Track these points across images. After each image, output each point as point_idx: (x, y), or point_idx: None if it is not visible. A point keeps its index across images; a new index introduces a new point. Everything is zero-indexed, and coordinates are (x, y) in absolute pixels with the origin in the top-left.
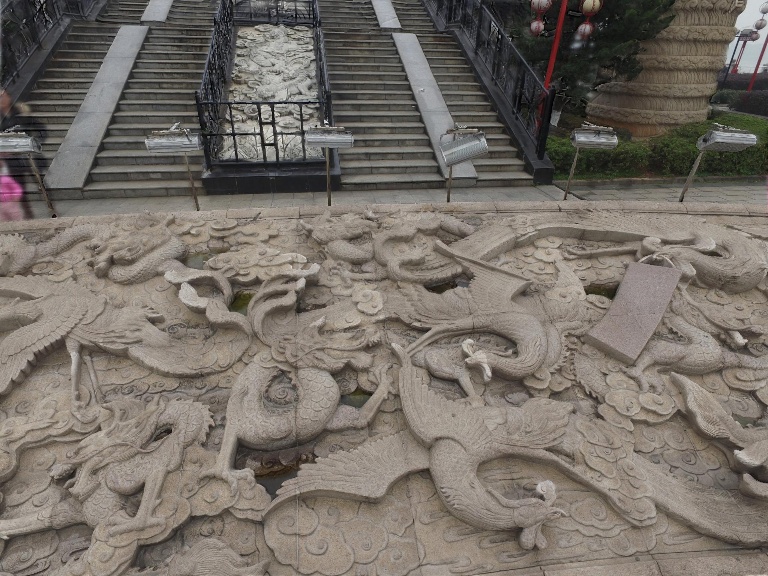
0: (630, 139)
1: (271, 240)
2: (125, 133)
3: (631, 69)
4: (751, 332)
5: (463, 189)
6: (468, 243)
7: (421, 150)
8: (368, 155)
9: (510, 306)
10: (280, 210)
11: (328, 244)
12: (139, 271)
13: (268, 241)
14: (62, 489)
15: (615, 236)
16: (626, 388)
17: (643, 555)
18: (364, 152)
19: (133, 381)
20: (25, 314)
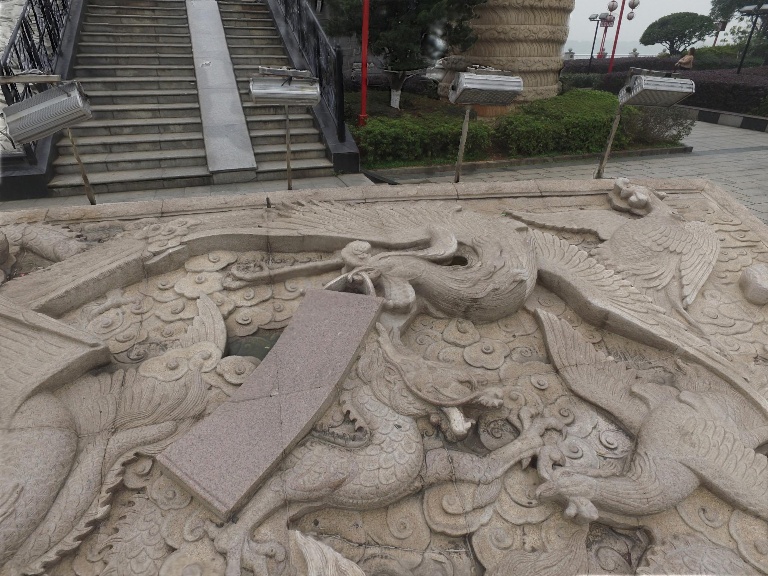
0: (474, 118)
1: None
2: None
3: (463, 37)
4: (481, 404)
5: (237, 185)
6: (42, 277)
7: (186, 137)
8: (107, 146)
9: (5, 415)
10: None
11: None
12: None
13: None
14: None
15: (317, 243)
16: None
17: None
18: (99, 142)
19: None
20: None
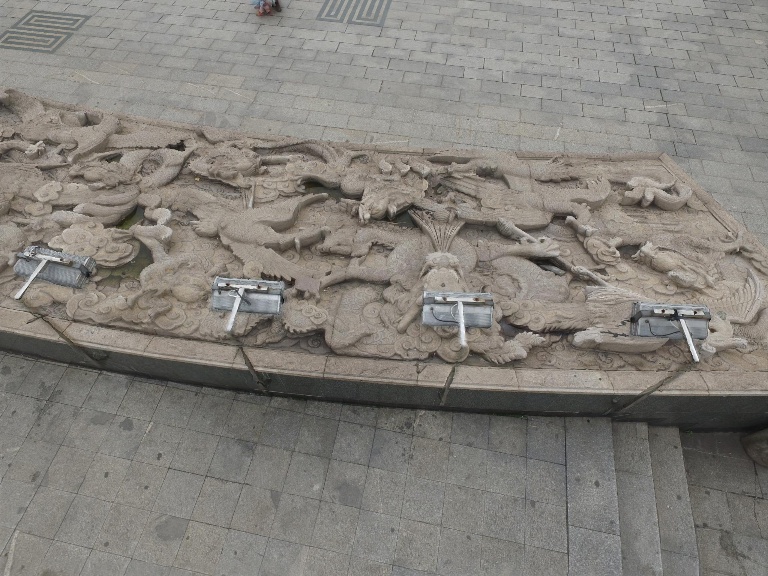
0: None
1: None
2: None
3: None
4: None
5: None
6: None
7: None
8: None
9: None
10: (2, 320)
11: None
12: None
13: None
14: None
15: None
16: None
17: (71, 111)
18: None
19: None
20: None
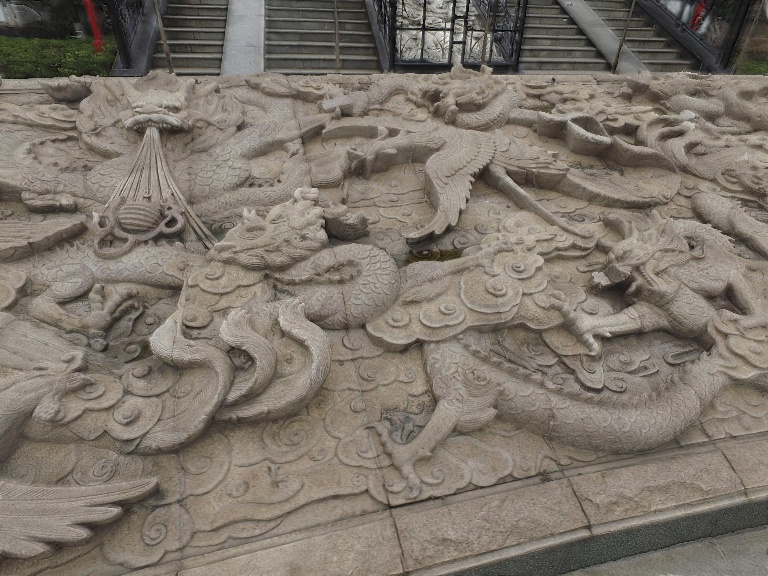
0: None
1: (590, 100)
2: (280, 37)
3: None
4: None
5: None
6: None
7: (592, 60)
8: (539, 64)
9: None
10: (573, 76)
11: (671, 99)
12: (499, 114)
13: (588, 101)
14: (604, 299)
15: None
16: None
17: None
18: (536, 60)
19: (576, 210)
20: (423, 143)
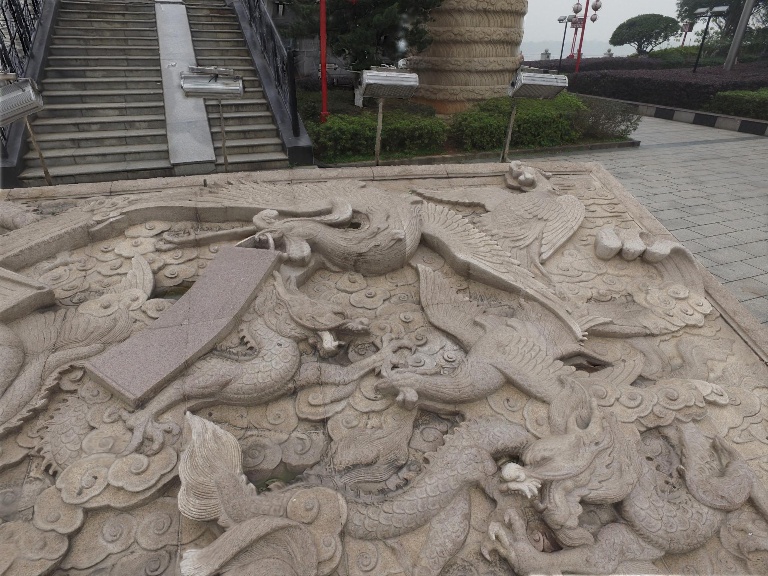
0: (432, 115)
1: None
2: None
3: (418, 39)
4: (349, 329)
5: None
6: (1, 240)
7: (150, 132)
8: (75, 141)
9: None
10: None
11: None
12: None
13: None
14: None
15: (238, 213)
16: (109, 450)
17: None
18: (68, 138)
19: None
20: None
